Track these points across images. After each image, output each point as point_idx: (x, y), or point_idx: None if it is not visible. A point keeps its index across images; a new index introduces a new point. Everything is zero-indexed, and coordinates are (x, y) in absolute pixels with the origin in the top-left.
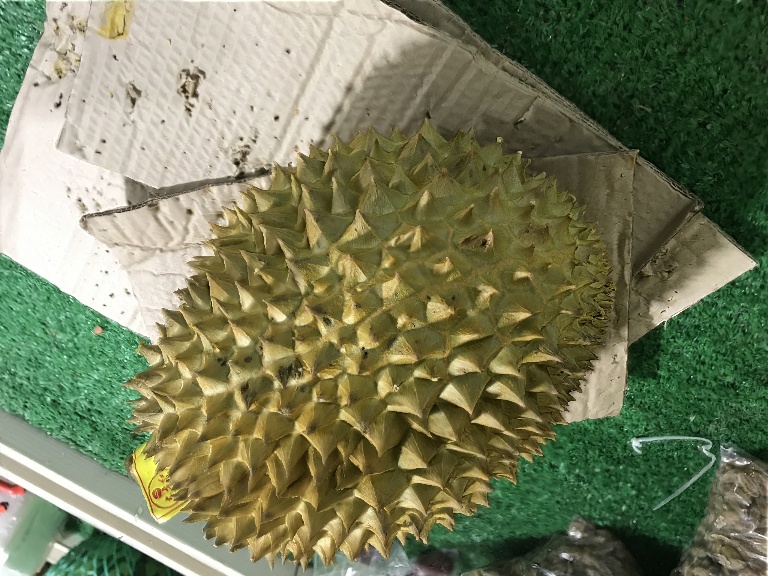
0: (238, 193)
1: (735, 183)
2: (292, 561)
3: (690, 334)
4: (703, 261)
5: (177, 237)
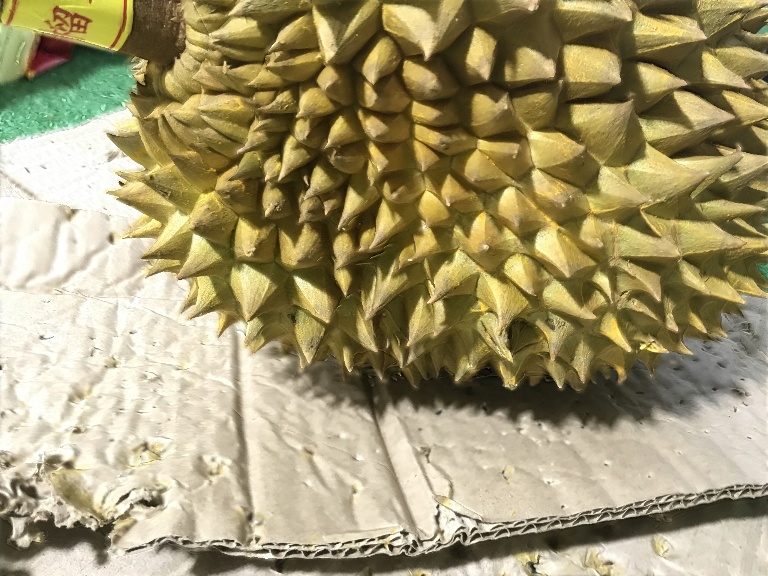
0: None
1: None
2: None
3: None
4: None
5: (60, 270)
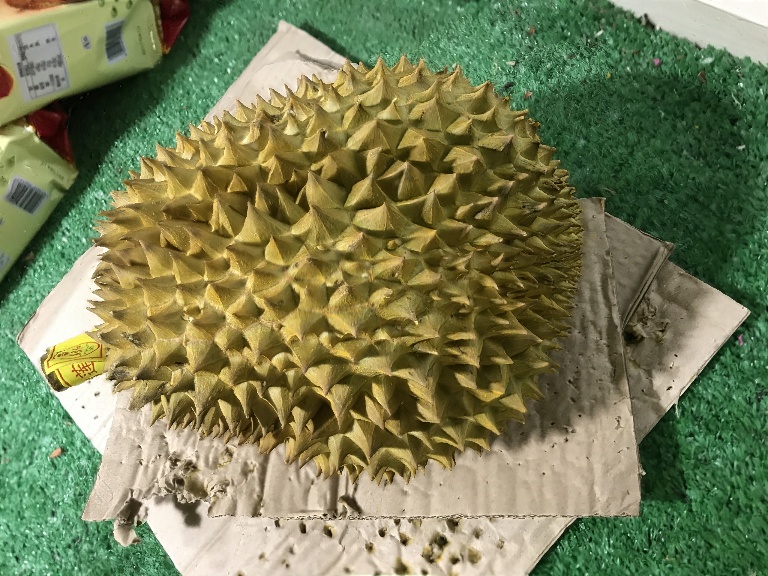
0: None
1: (704, 246)
2: (191, 317)
3: (710, 428)
4: (693, 312)
5: None
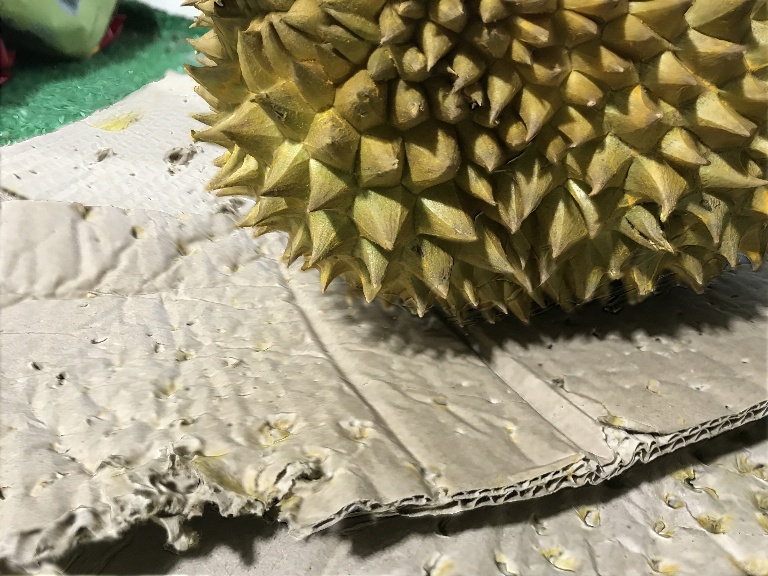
0: (222, 226)
1: None
2: None
3: None
4: None
5: (88, 272)
